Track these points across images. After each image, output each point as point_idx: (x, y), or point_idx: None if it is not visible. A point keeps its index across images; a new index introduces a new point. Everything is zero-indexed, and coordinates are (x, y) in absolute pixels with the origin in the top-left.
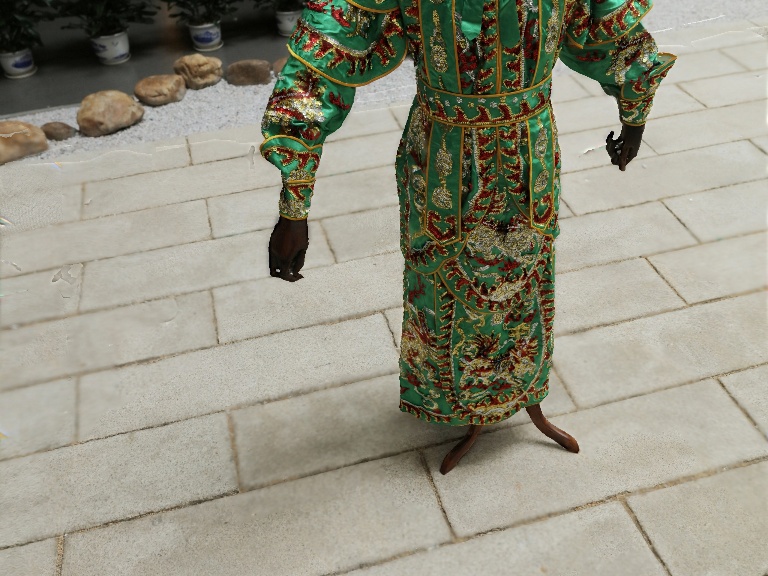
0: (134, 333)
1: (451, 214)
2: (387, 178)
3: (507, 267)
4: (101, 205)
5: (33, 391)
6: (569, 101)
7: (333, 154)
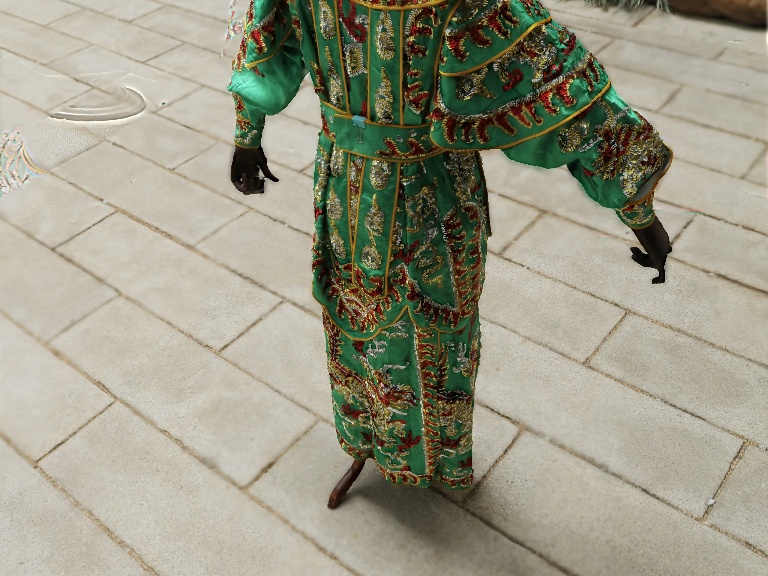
0: None
1: None
2: None
3: None
4: None
5: None
6: None
7: None
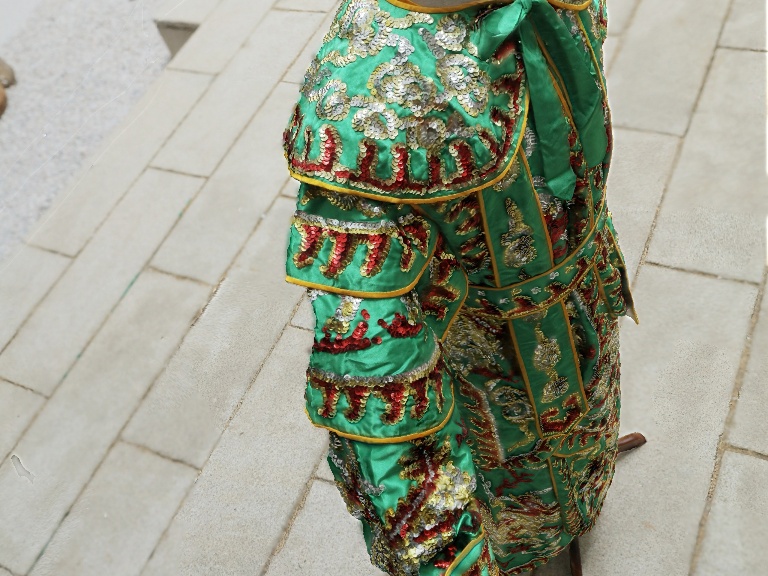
0: None
1: (569, 395)
2: (130, 326)
3: (610, 379)
4: None
5: None
6: (202, 96)
7: (35, 350)
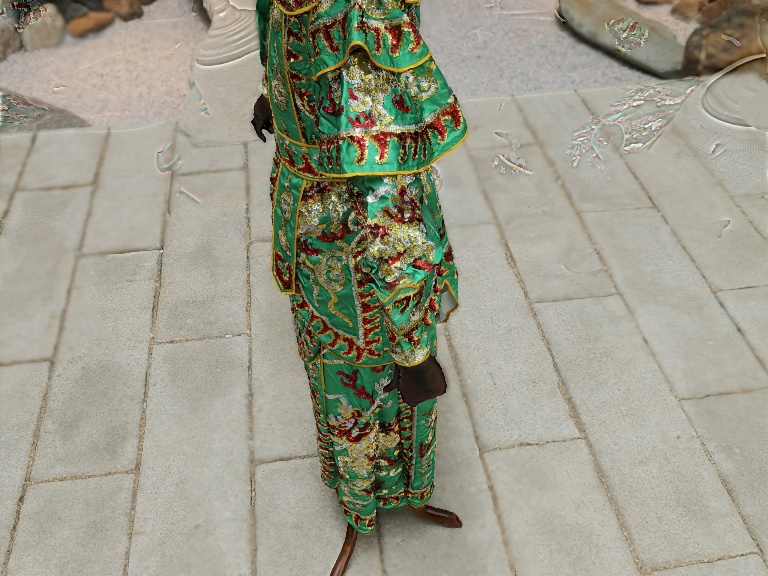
0: (549, 247)
1: None
2: None
3: None
4: (763, 206)
5: (479, 201)
6: None
7: None
